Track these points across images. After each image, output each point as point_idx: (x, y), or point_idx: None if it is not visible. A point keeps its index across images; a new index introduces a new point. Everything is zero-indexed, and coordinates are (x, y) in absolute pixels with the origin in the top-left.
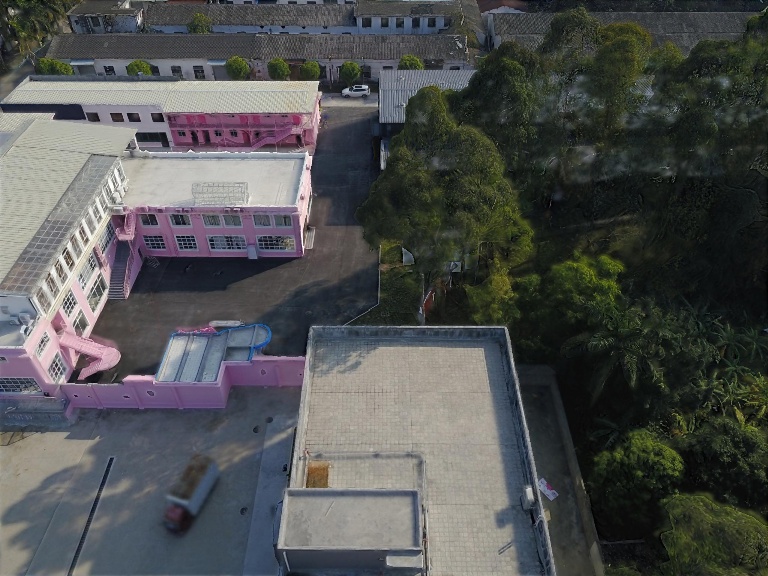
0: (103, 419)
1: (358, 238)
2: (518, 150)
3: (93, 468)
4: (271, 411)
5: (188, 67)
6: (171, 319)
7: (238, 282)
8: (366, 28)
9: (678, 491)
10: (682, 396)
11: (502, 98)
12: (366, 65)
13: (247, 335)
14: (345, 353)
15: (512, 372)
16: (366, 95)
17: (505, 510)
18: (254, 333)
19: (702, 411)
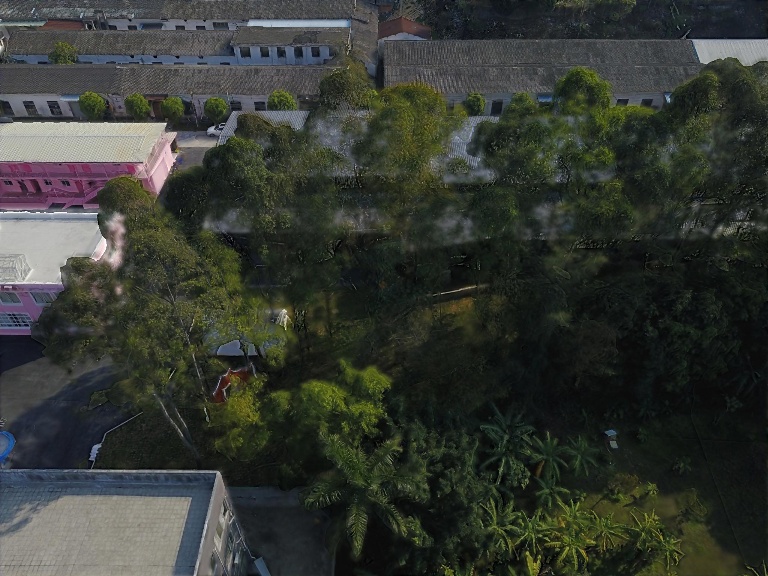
0: None
1: None
2: (267, 242)
3: None
4: None
5: (42, 102)
6: None
7: (17, 368)
8: (245, 58)
9: None
10: (463, 539)
11: (230, 185)
12: (235, 100)
13: None
14: (19, 504)
15: (201, 541)
16: None
17: None
18: None
19: (495, 552)
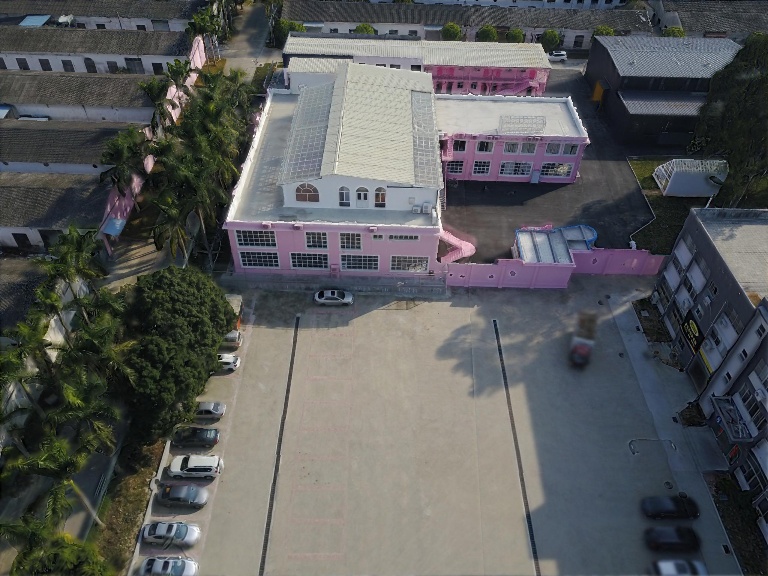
0: (472, 294)
1: (614, 170)
2: None
3: (484, 326)
4: (606, 291)
5: (404, 31)
6: (491, 225)
7: (530, 200)
8: (550, 3)
9: None
10: None
11: None
12: (561, 34)
13: (576, 233)
14: (720, 228)
15: None
16: (564, 60)
17: None
18: (583, 231)
19: None
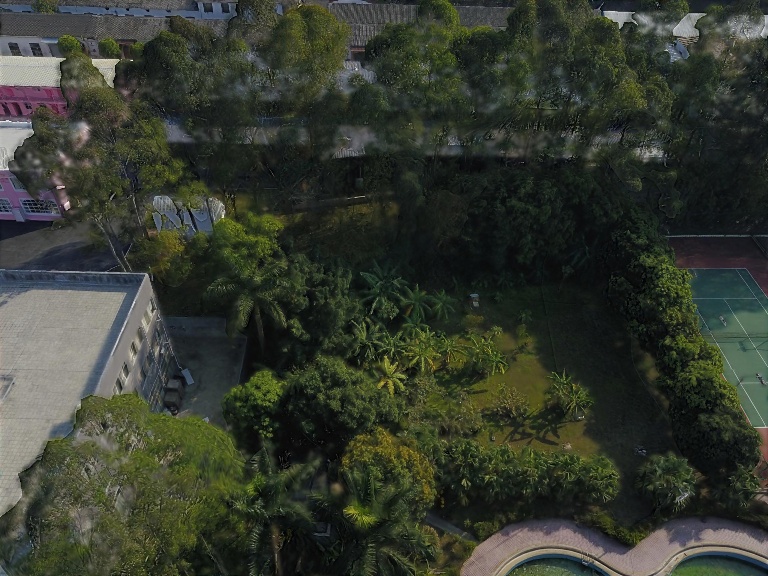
0: None
1: None
2: (192, 117)
3: None
4: None
5: (25, 44)
6: None
7: None
8: (208, 13)
9: (268, 419)
10: (336, 345)
11: (162, 67)
12: None
13: None
14: None
15: None
16: None
17: (63, 424)
18: None
19: (364, 361)
